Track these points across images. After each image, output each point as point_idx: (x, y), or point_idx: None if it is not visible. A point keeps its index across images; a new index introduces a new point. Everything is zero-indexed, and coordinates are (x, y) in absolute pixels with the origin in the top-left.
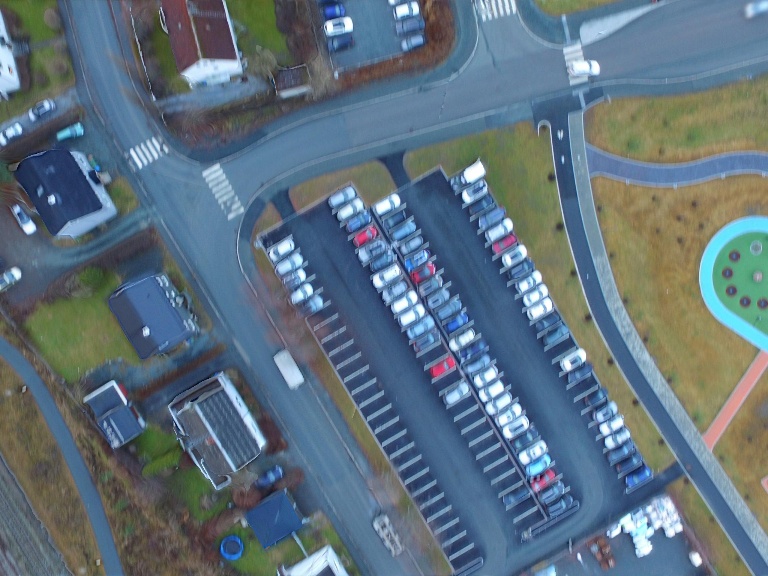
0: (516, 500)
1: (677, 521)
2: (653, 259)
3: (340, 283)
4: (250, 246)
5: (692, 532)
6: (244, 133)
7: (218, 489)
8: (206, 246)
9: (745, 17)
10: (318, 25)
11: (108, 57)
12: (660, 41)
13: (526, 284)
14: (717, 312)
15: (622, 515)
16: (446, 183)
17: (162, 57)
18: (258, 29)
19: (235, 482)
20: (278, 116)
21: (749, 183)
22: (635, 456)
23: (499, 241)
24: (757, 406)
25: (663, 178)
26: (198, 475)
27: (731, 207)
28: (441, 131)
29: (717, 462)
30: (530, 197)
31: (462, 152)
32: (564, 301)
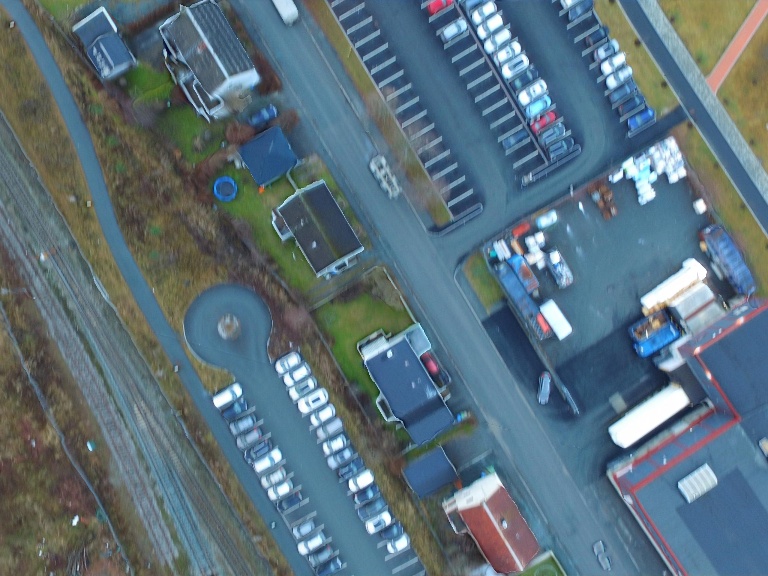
0: (516, 141)
1: (681, 163)
2: None
3: None
4: None
5: (696, 176)
6: None
7: (211, 113)
8: None
9: None
10: None
11: None
12: None
13: None
14: None
15: (624, 158)
16: None
17: None
18: None
19: (228, 107)
20: None
21: None
22: (637, 96)
23: None
24: (762, 47)
25: None
26: (190, 116)
27: None
28: None
29: (721, 106)
30: None
31: None
32: None
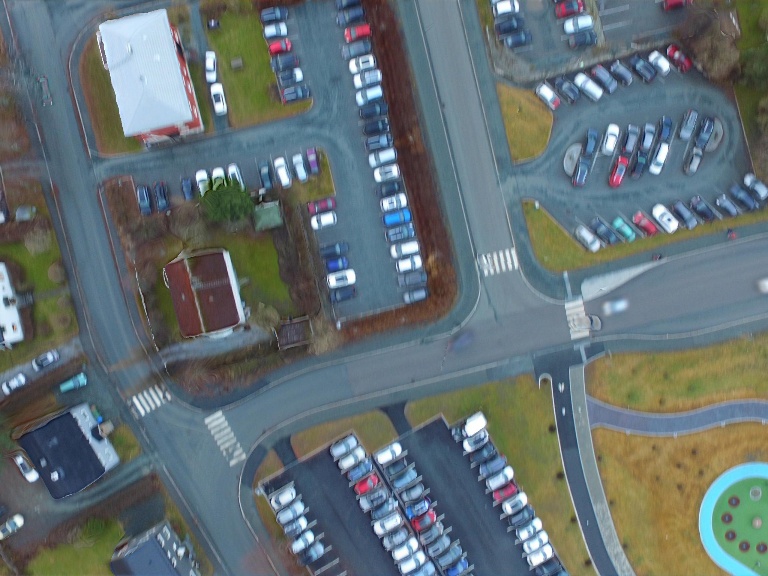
0: None
1: None
2: (653, 506)
3: (341, 528)
4: (252, 492)
5: None
6: (246, 384)
7: None
8: (208, 492)
9: (746, 275)
10: (321, 276)
11: (111, 306)
12: (661, 298)
13: (526, 533)
14: (716, 557)
15: None
16: (447, 431)
17: (165, 308)
18: (261, 279)
19: None
20: (280, 365)
21: (749, 431)
22: None
23: (500, 489)
24: None
25: (663, 428)
26: None
27: (731, 454)
28: (443, 383)
29: None
30: (531, 448)
31: (463, 402)
32: (564, 547)
